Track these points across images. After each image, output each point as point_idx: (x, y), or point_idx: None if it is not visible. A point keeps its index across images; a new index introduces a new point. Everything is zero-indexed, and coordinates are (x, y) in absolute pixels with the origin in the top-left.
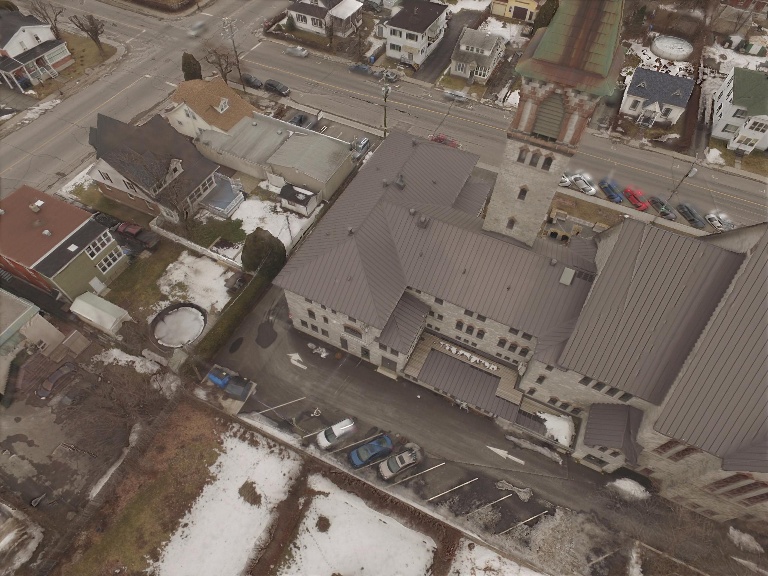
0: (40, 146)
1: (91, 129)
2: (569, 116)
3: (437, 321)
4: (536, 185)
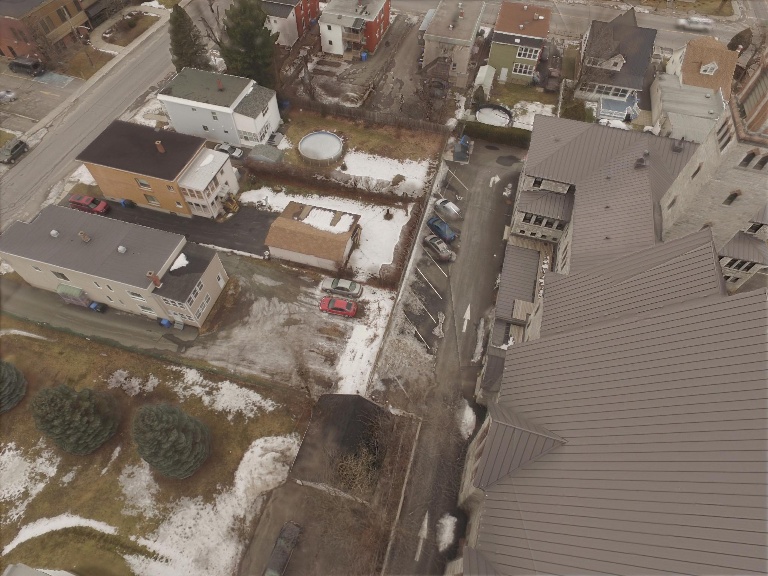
0: None
1: (620, 15)
2: (766, 93)
3: (563, 239)
4: (707, 165)
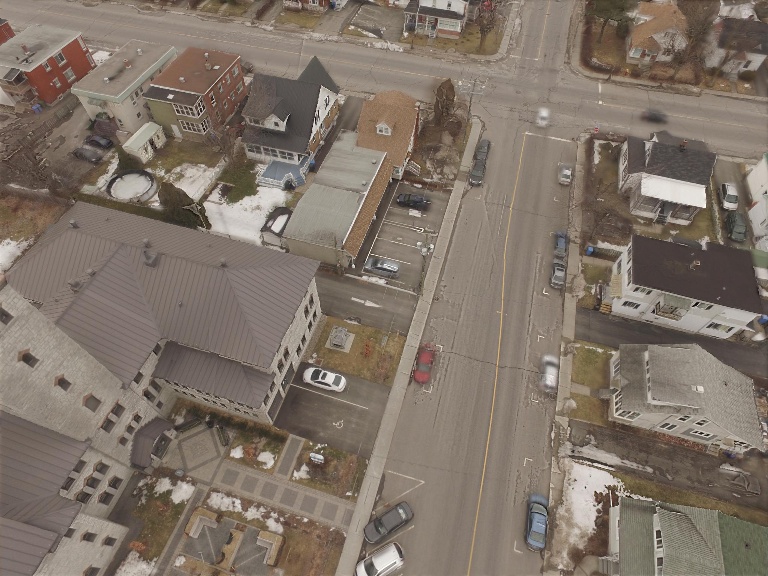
0: (340, 61)
1: None
2: None
3: None
4: None
